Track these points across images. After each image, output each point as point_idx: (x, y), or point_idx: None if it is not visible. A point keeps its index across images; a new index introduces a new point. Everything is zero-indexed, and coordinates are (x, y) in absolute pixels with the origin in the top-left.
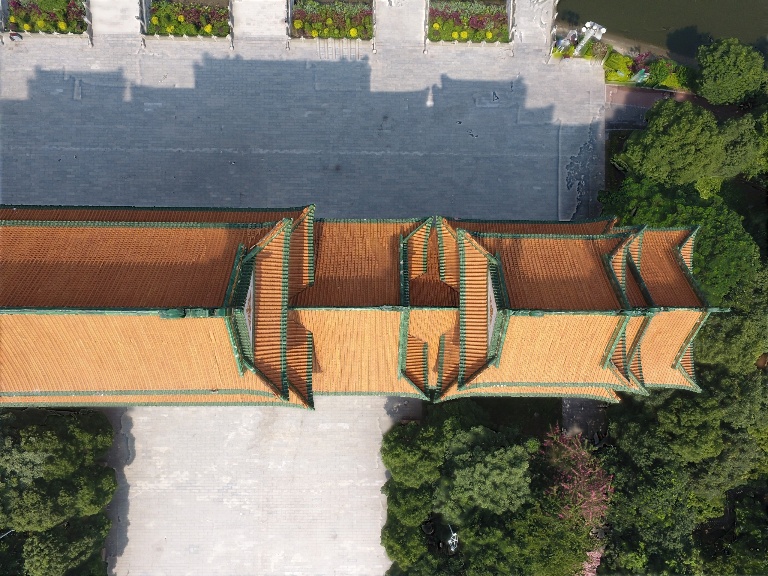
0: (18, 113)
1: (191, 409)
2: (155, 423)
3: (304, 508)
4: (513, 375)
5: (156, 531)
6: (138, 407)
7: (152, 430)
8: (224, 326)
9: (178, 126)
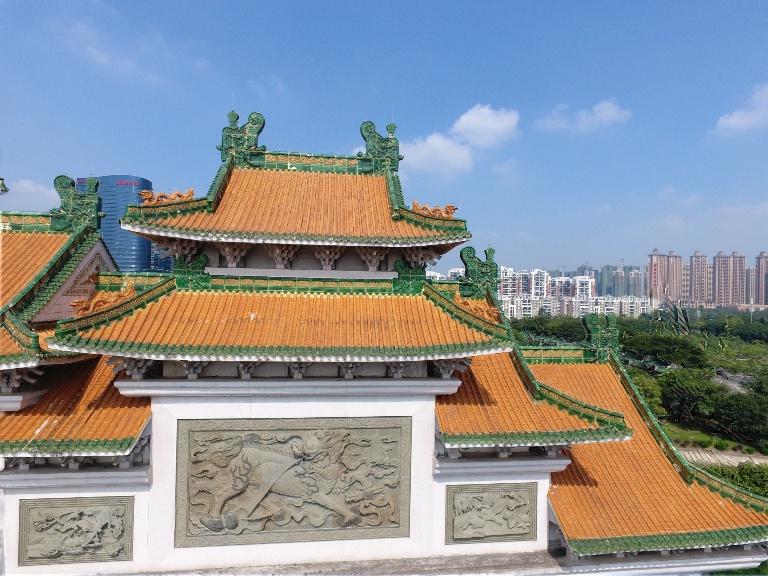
0: None
1: None
2: None
3: None
4: (243, 228)
5: None
6: None
7: None
8: None
9: None
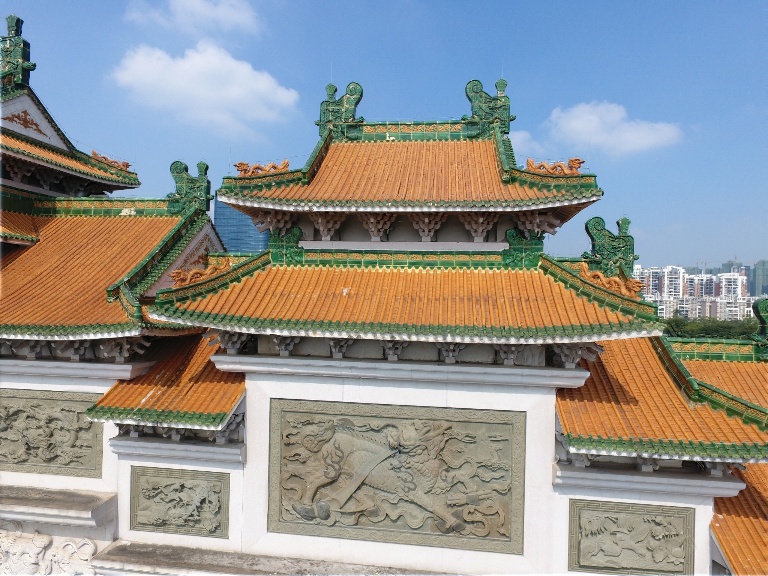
0: None
1: None
2: None
3: None
4: (337, 197)
5: None
6: None
7: None
8: None
9: None
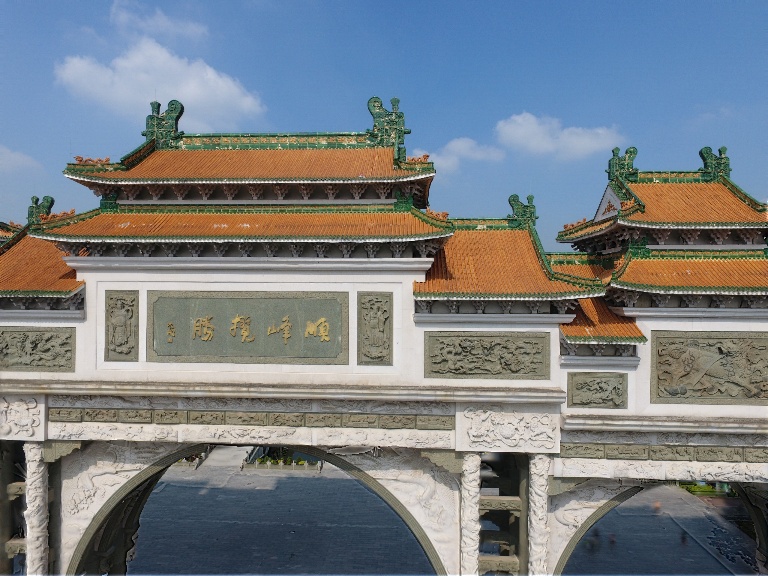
0: None
1: None
2: None
3: None
4: None
5: None
6: None
7: None
8: (389, 153)
9: (244, 508)
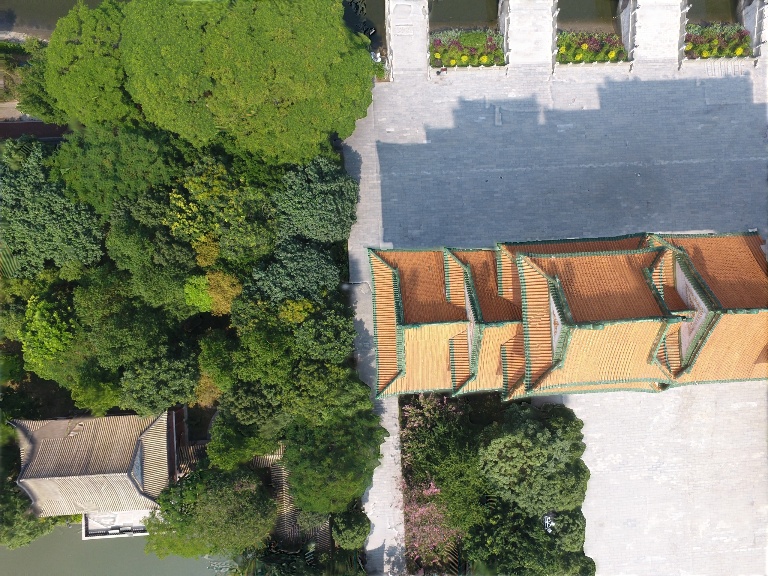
0: (447, 141)
1: (619, 398)
2: (588, 412)
3: (724, 480)
4: None
5: (597, 509)
6: (572, 399)
7: (586, 419)
8: None
9: (588, 144)
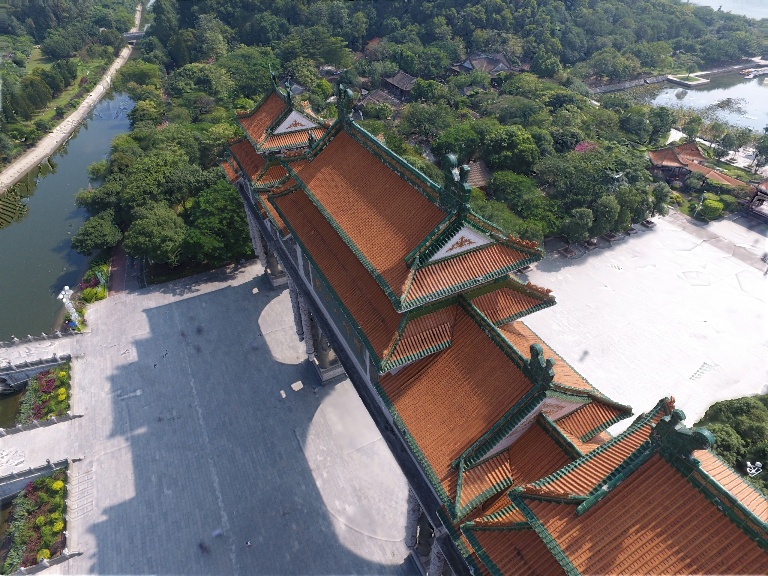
0: None
1: None
2: None
3: None
4: None
5: None
6: None
7: None
8: None
9: None
